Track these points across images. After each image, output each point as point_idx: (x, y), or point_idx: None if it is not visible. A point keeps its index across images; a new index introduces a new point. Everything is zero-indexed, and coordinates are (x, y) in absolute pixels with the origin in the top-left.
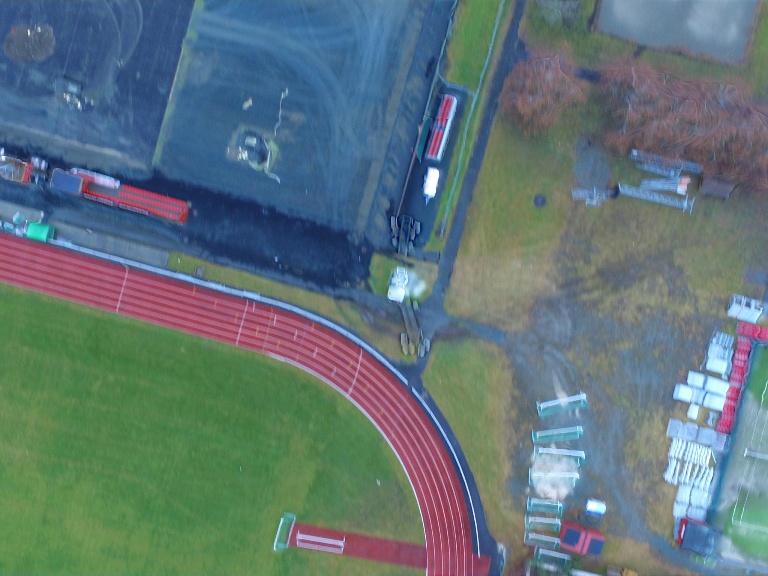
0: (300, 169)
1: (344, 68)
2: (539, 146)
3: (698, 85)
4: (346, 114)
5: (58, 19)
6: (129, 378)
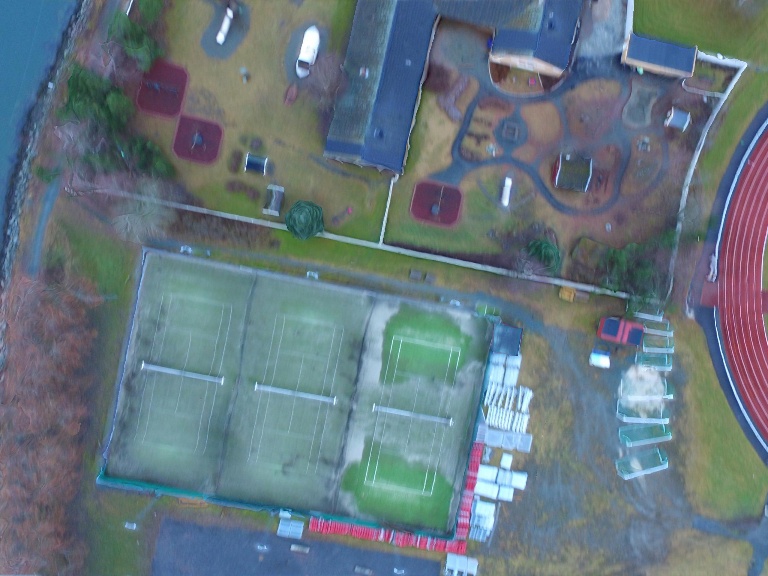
0: None
1: None
2: None
3: None
4: None
5: None
6: None
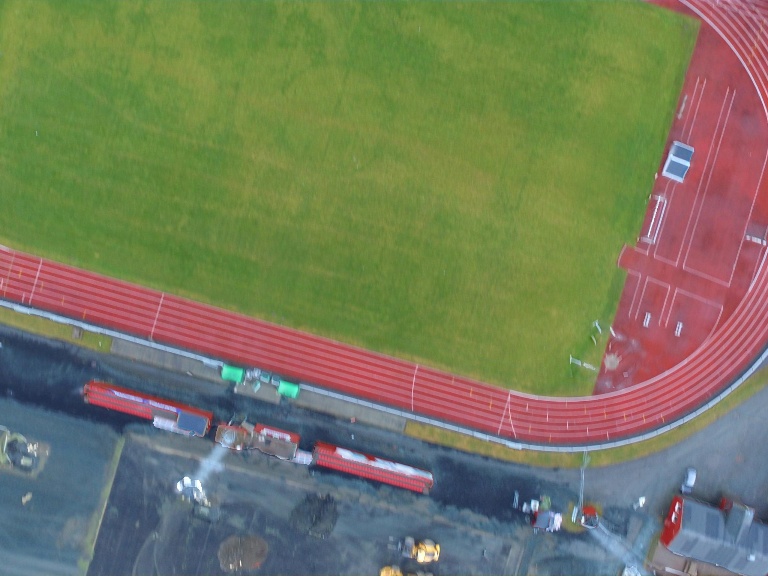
0: None
1: None
2: None
3: None
4: None
5: None
6: (151, 228)
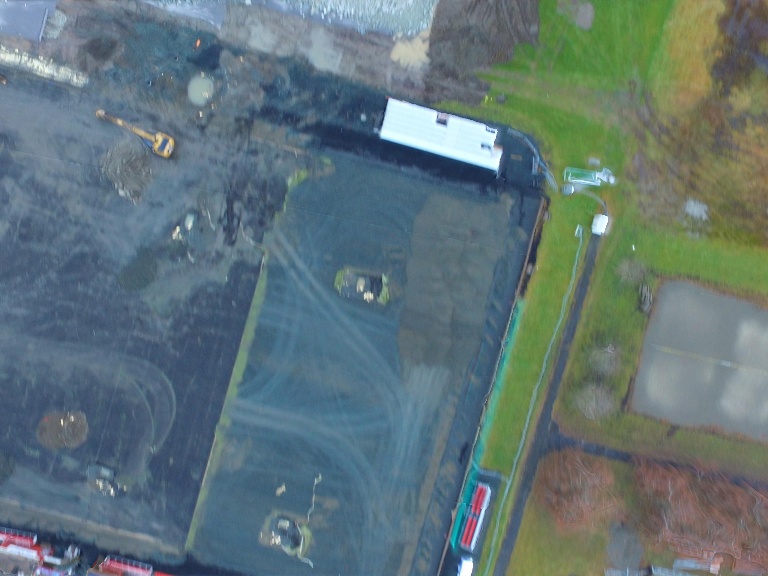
0: (333, 554)
1: (377, 454)
2: (572, 527)
3: (734, 496)
4: (379, 499)
5: (91, 406)
6: None
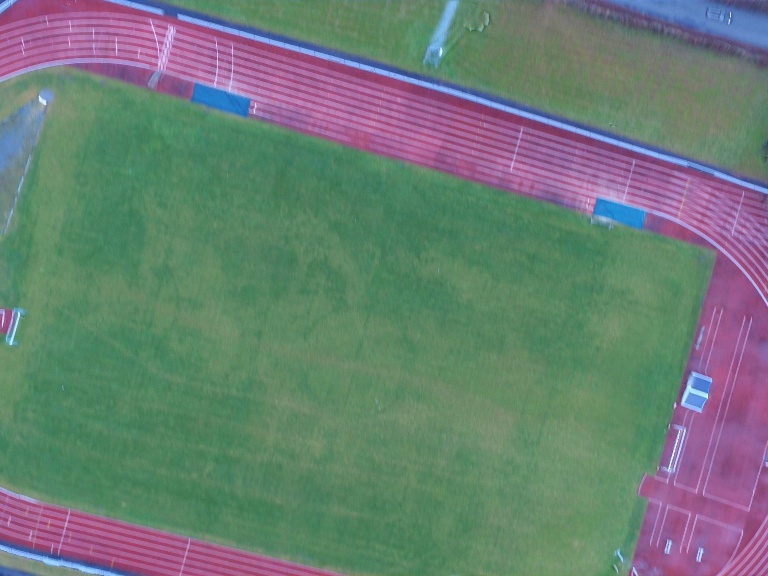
0: None
1: None
2: None
3: None
4: None
5: None
6: (177, 476)
